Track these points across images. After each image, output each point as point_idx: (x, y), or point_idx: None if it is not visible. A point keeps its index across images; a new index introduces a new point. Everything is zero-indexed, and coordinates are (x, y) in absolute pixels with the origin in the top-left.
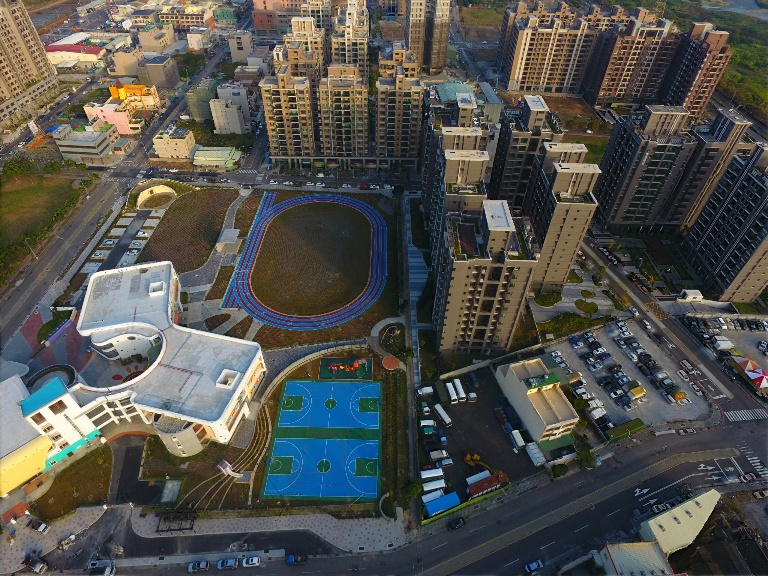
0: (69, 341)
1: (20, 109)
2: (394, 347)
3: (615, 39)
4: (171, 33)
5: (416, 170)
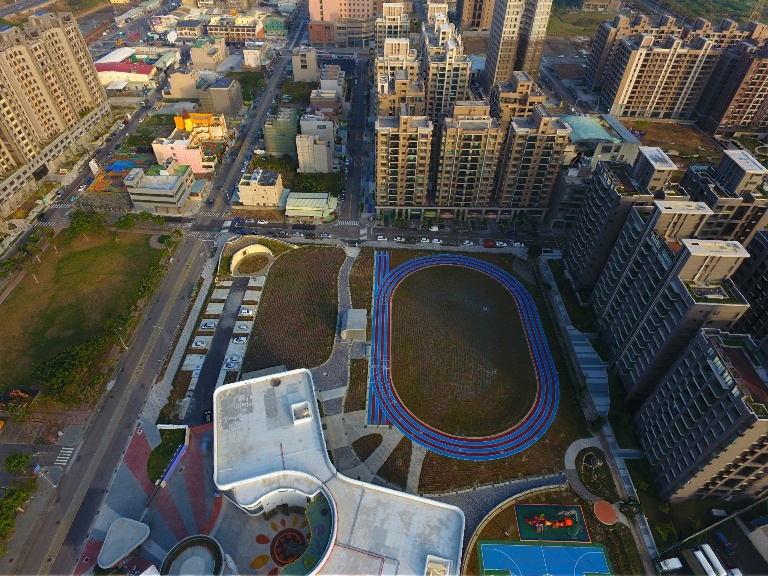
0: (189, 478)
1: (74, 142)
2: (602, 487)
3: (749, 62)
4: (223, 48)
5: (542, 221)
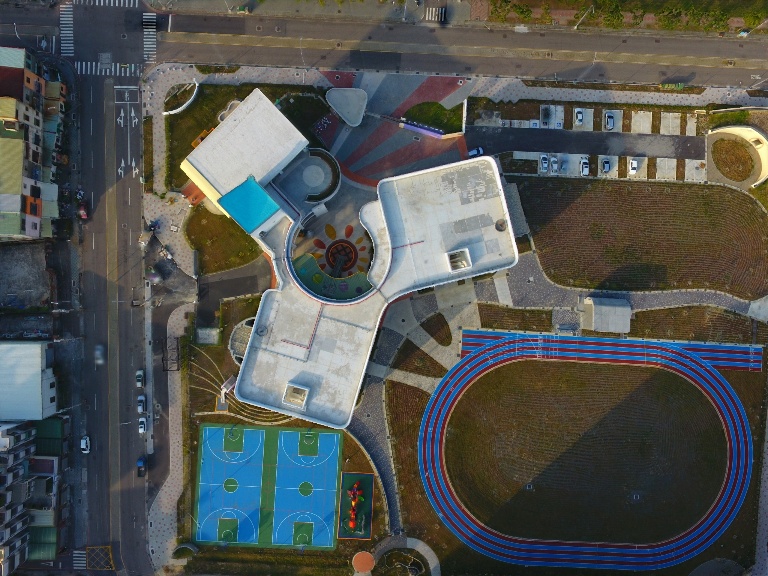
0: (408, 149)
1: None
2: (388, 568)
3: None
4: None
5: None
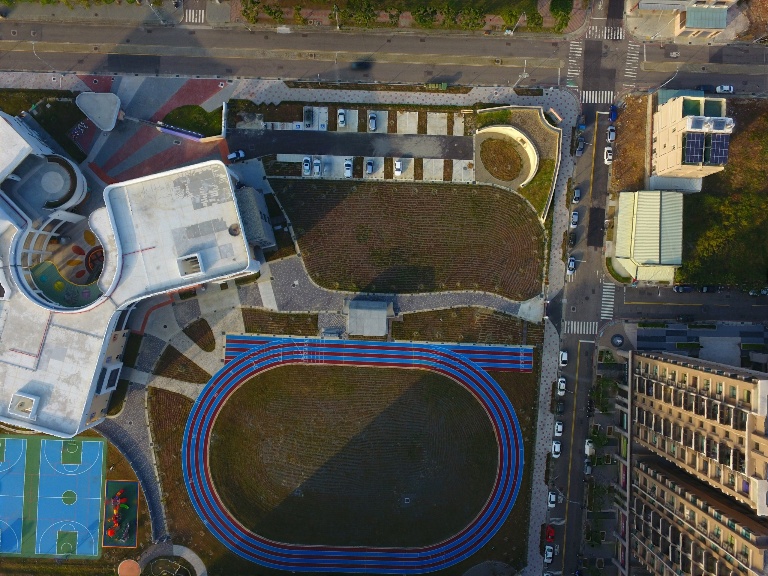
0: (167, 153)
1: None
2: (154, 575)
3: None
4: None
5: None
